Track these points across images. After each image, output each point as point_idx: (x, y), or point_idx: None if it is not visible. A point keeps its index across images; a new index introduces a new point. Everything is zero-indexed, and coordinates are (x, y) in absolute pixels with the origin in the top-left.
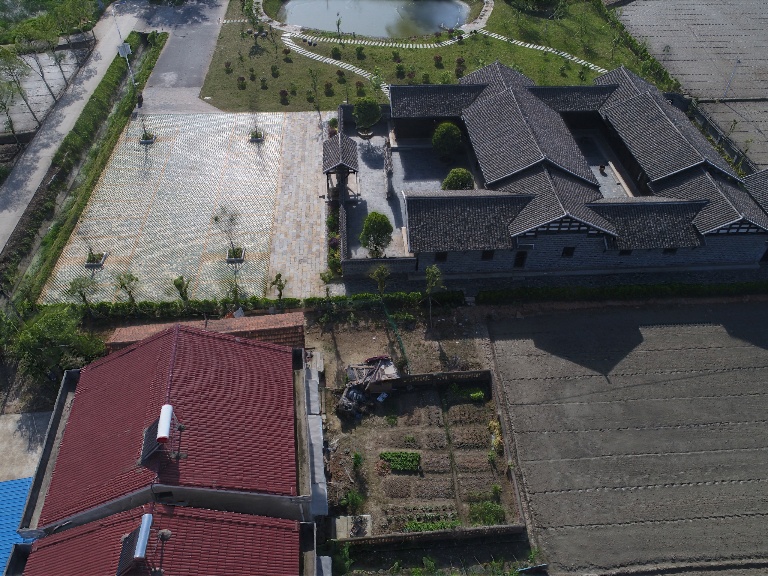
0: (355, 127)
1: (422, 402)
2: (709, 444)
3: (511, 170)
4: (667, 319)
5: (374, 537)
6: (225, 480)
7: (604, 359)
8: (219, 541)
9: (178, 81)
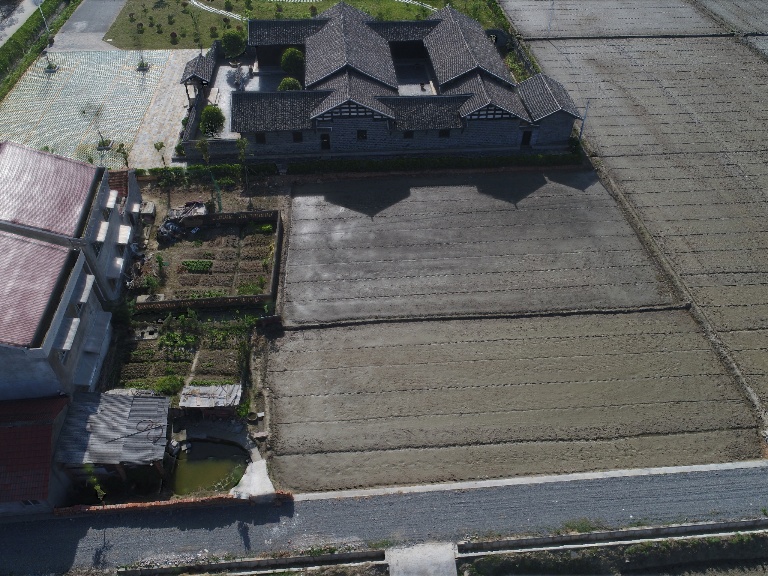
0: (227, 59)
1: (225, 233)
2: (432, 255)
3: (324, 75)
4: (434, 183)
5: (159, 301)
6: (19, 220)
7: (374, 207)
8: (5, 246)
9: (87, 28)
